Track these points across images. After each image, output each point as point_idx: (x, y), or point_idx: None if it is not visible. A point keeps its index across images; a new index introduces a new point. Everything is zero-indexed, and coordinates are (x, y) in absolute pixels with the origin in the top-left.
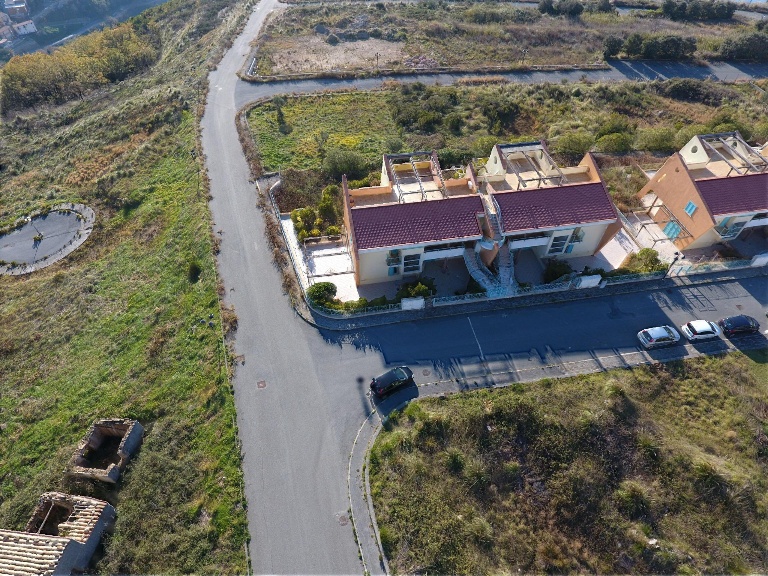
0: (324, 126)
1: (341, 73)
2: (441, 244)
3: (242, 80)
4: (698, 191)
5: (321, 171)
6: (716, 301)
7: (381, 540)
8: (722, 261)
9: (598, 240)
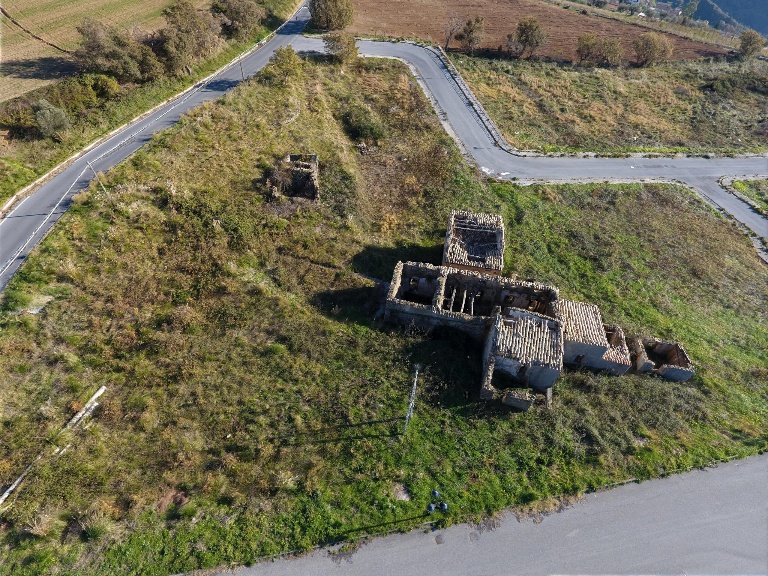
0: None
1: None
2: None
3: None
4: None
5: None
6: None
7: None
8: None
9: None
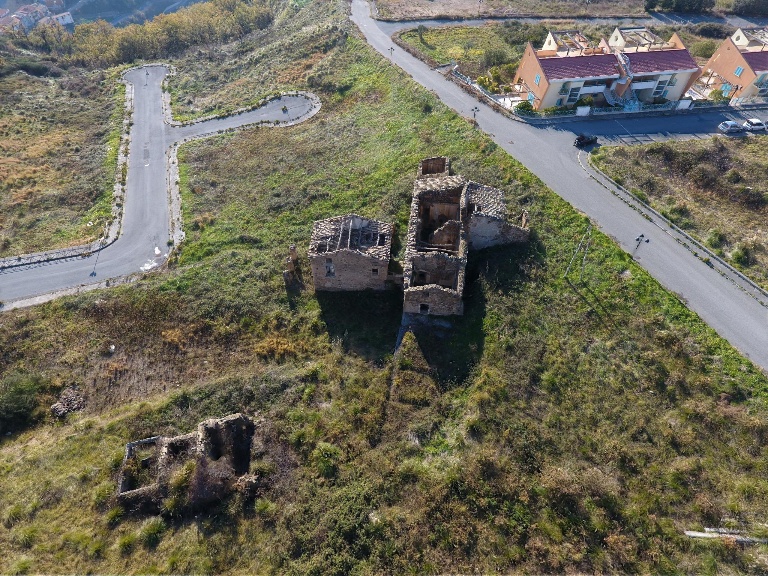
0: (458, 45)
1: (452, 15)
2: (594, 80)
3: (378, 20)
4: (744, 58)
5: (479, 63)
6: (761, 116)
7: (616, 179)
8: (762, 97)
9: (683, 88)
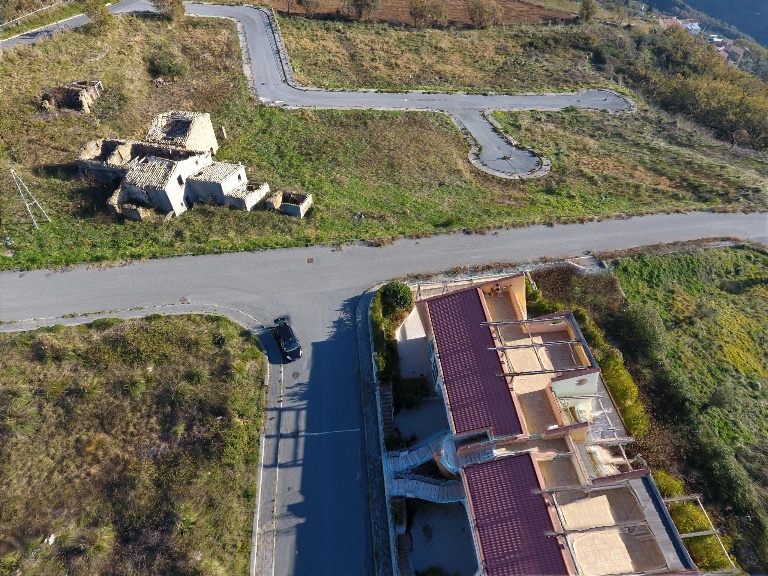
0: (766, 328)
1: None
2: None
3: None
4: None
5: (626, 310)
6: None
7: None
8: None
9: None
